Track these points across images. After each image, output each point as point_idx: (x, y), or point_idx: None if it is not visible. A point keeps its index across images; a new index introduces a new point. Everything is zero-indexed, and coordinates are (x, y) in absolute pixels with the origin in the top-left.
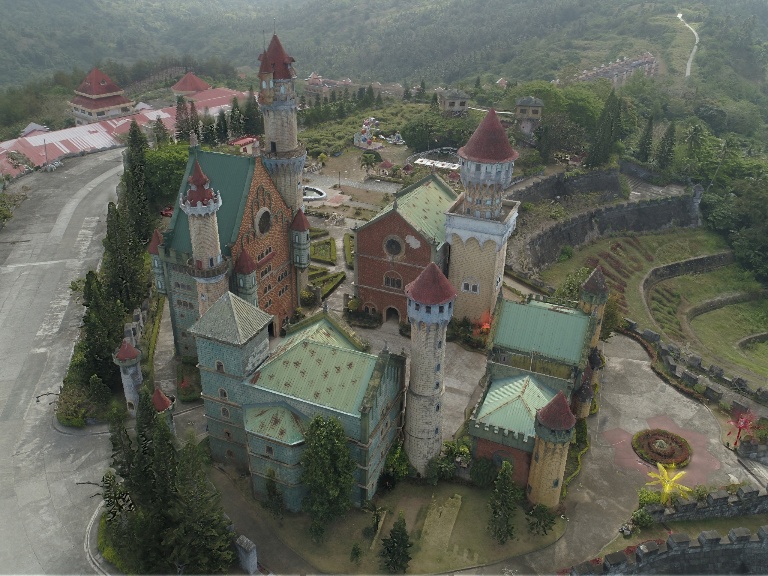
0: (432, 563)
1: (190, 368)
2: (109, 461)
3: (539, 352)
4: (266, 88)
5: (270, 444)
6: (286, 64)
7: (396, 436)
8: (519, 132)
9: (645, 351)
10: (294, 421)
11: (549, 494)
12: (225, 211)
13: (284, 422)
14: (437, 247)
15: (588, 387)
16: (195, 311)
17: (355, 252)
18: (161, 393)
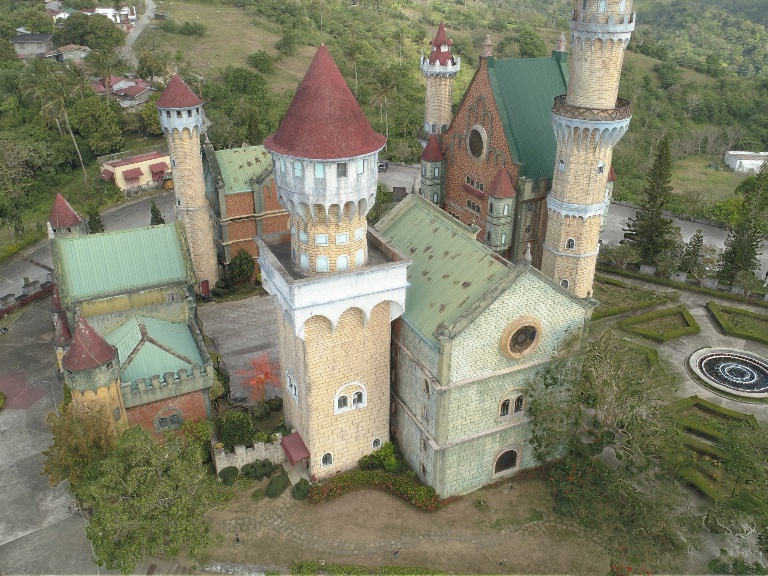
0: None
1: None
2: None
3: None
4: None
5: None
6: None
7: (223, 256)
8: None
9: (2, 572)
10: None
11: None
12: None
13: None
14: None
15: None
16: None
17: None
18: None
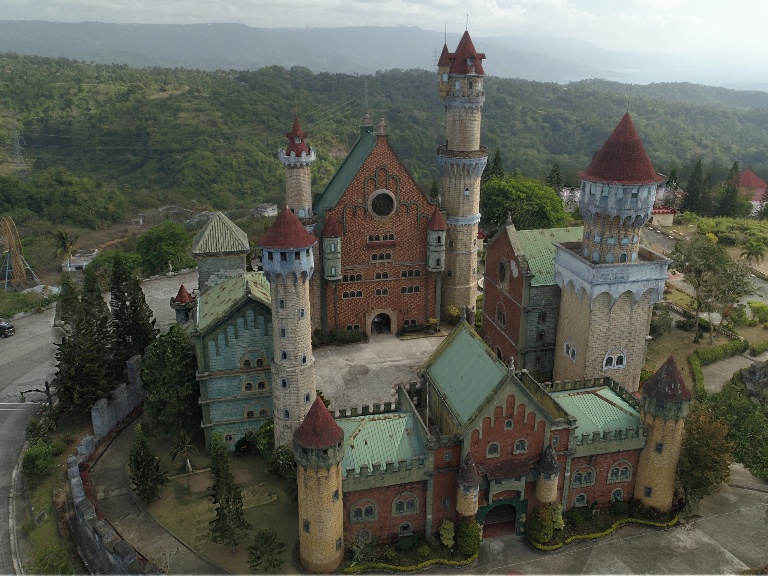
0: (174, 518)
1: None
2: None
3: (447, 397)
4: (439, 81)
5: None
6: (465, 59)
7: None
8: None
9: None
10: None
11: (303, 538)
12: None
13: None
14: (536, 282)
15: (465, 467)
16: None
17: (484, 273)
18: (183, 290)
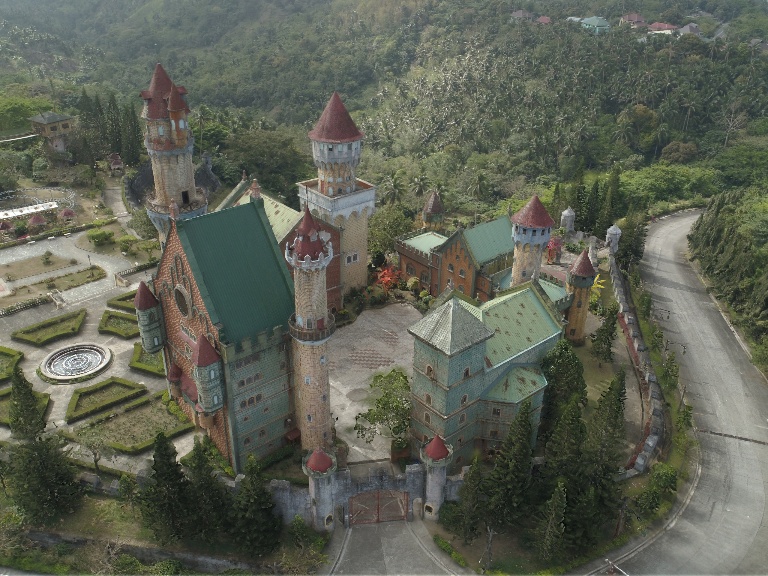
0: None
1: (283, 465)
2: (392, 567)
3: (501, 253)
4: (185, 127)
5: (530, 400)
6: None
7: None
8: (55, 152)
9: None
10: (528, 371)
11: None
12: (262, 270)
13: (527, 376)
14: None
15: None
16: (265, 400)
17: None
18: None
